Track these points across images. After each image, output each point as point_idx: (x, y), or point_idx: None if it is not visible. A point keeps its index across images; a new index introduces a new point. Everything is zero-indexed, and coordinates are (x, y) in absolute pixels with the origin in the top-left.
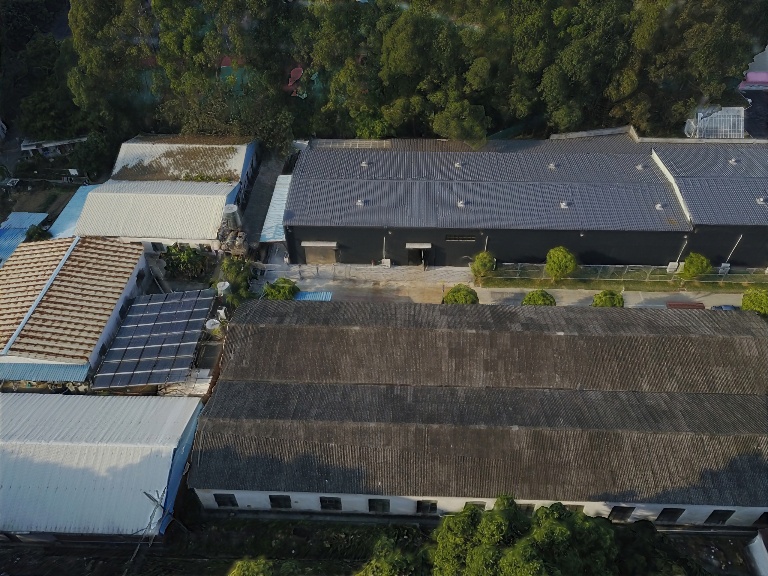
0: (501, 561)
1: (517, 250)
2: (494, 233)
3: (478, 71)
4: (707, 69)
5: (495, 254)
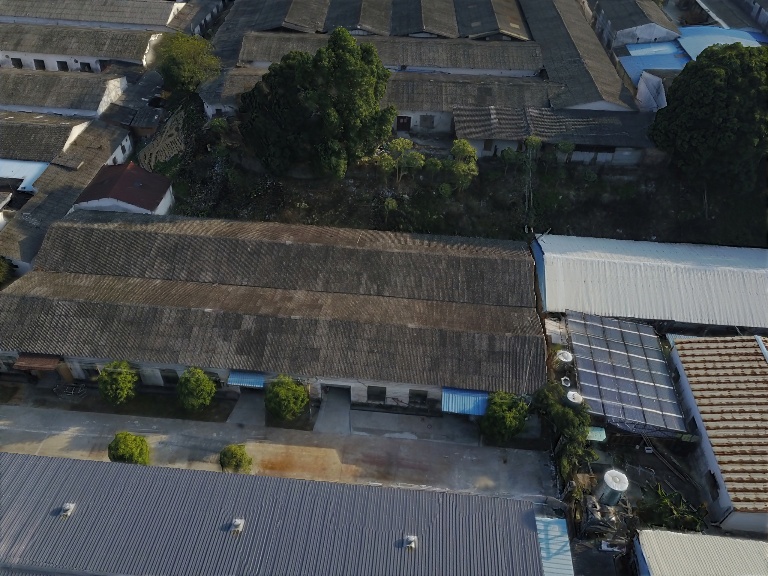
0: (351, 46)
1: None
2: None
3: None
4: None
5: None
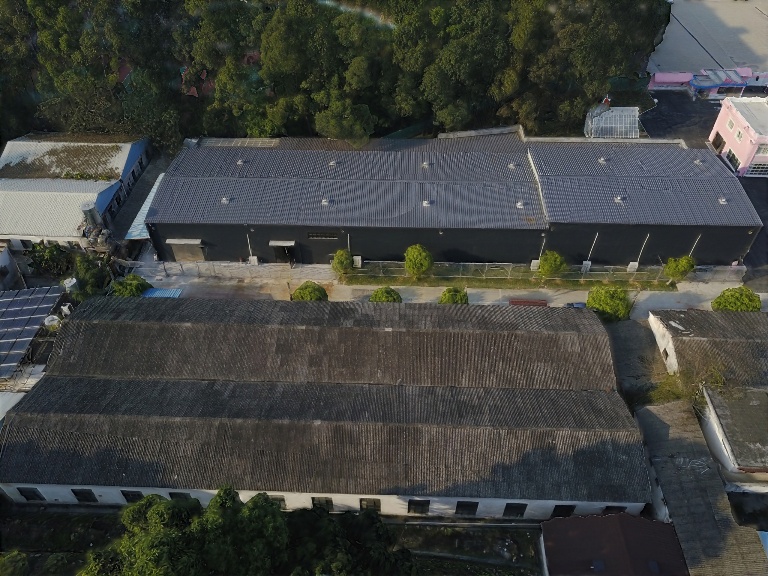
0: None
1: (381, 248)
2: (354, 231)
3: (355, 70)
4: (586, 69)
5: (360, 252)
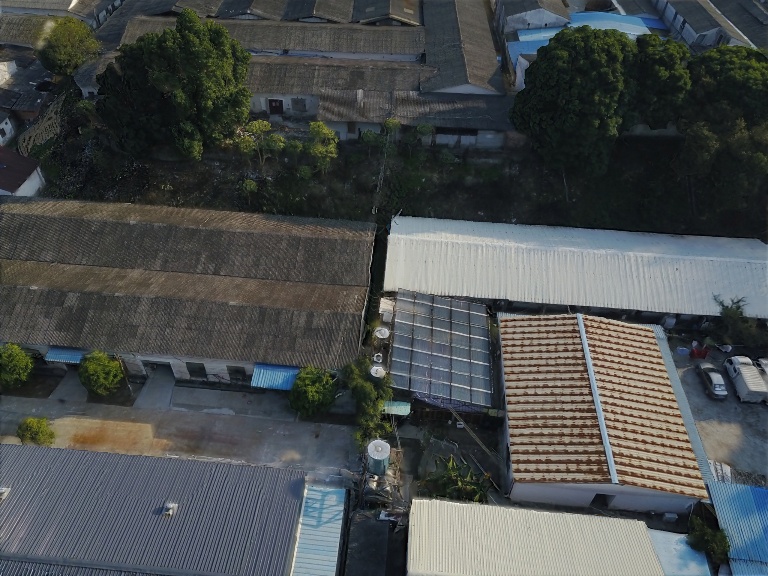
0: (198, 27)
1: None
2: None
3: None
4: None
5: None
